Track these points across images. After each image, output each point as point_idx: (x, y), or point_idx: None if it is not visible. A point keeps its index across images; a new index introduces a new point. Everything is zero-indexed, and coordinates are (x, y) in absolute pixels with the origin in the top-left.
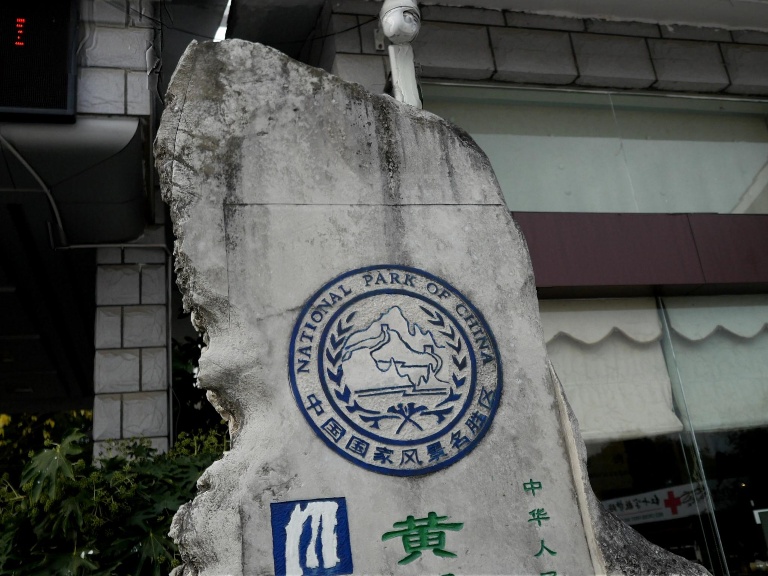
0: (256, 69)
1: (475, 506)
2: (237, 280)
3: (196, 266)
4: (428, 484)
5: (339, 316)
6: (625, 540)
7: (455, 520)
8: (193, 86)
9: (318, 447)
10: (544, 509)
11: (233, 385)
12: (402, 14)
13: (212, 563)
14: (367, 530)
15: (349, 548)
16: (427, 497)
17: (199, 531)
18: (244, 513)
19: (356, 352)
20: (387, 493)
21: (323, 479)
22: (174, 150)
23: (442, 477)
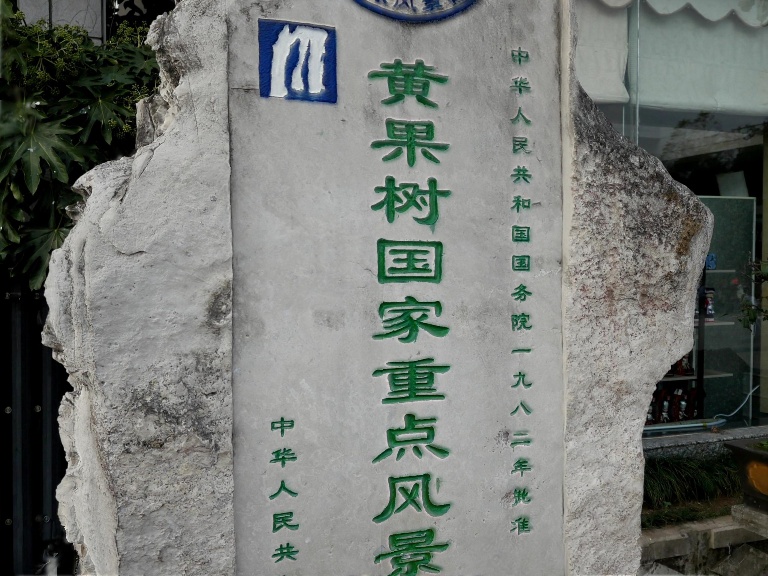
0: None
1: (462, 62)
2: None
3: None
4: (419, 31)
5: None
6: (597, 119)
7: (441, 72)
8: None
9: None
10: (527, 78)
11: None
12: None
13: (195, 68)
14: (354, 64)
15: (335, 78)
16: (417, 44)
17: (182, 34)
18: (231, 23)
19: None
20: (378, 32)
21: (314, 4)
22: None
23: (434, 27)
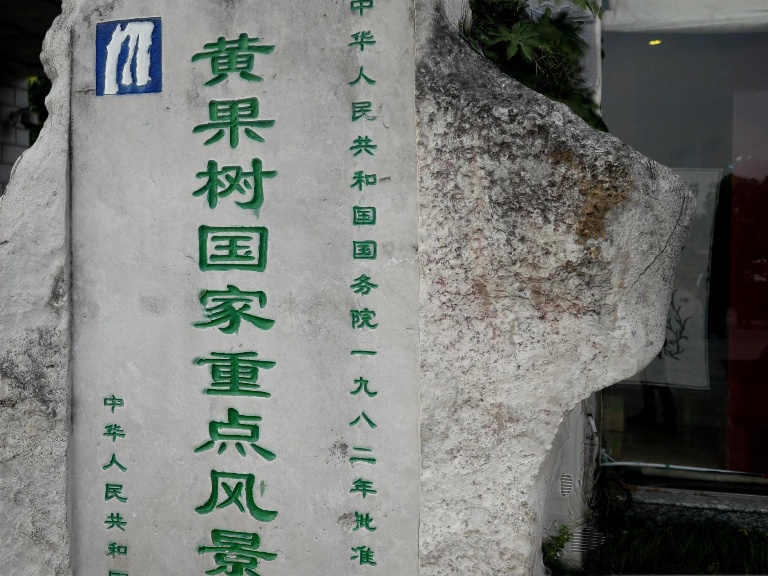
0: None
1: (291, 27)
2: None
3: None
4: (244, 3)
5: None
6: (455, 67)
7: (267, 42)
8: None
9: None
10: (370, 31)
11: None
12: None
13: (55, 78)
14: (179, 50)
15: (160, 67)
16: (241, 17)
17: (48, 50)
18: (75, 32)
19: None
20: (201, 13)
21: None
22: None
23: None
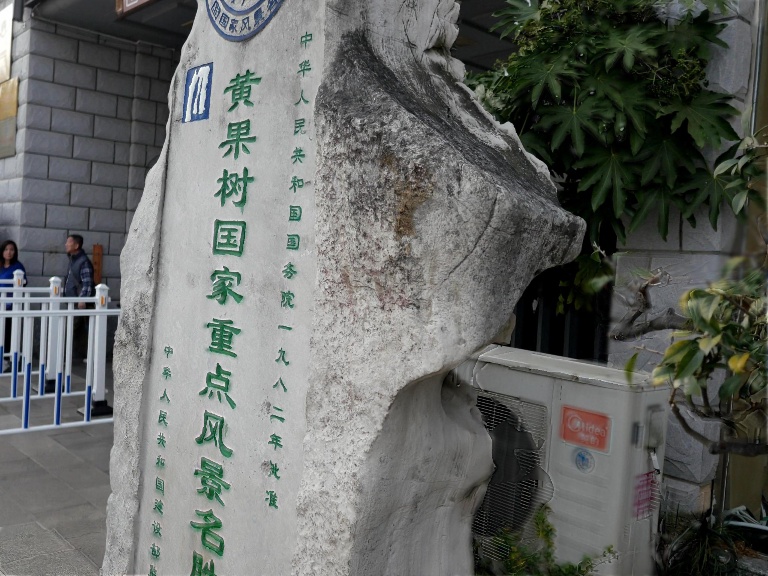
0: None
1: (270, 62)
2: None
3: None
4: (250, 46)
5: None
6: (343, 86)
7: (258, 75)
8: None
9: (208, 25)
10: (309, 60)
11: None
12: None
13: None
14: None
15: (209, 100)
16: (248, 57)
17: None
18: None
19: None
20: (230, 56)
21: (207, 49)
22: None
23: (258, 39)
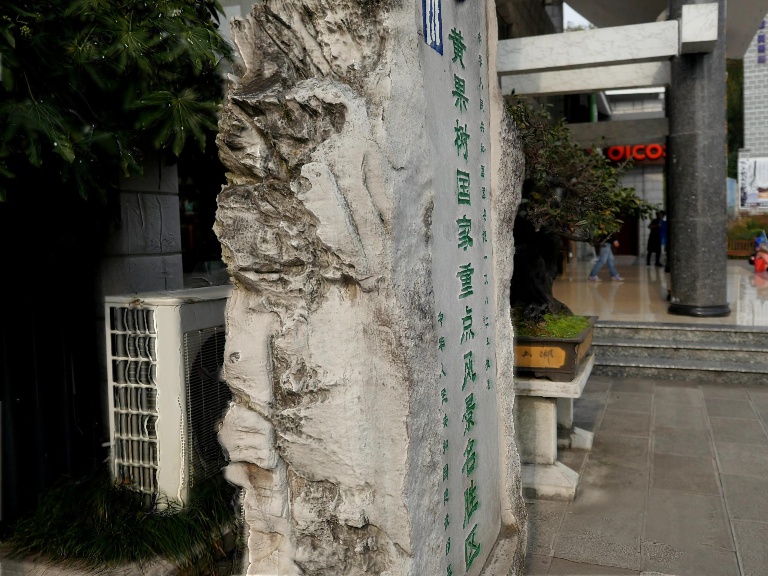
0: None
1: None
2: None
3: None
4: None
5: None
6: None
7: None
8: None
9: None
10: None
11: None
12: None
13: (397, 7)
14: None
15: None
16: None
17: None
18: None
19: None
20: (450, 3)
21: None
22: None
23: None
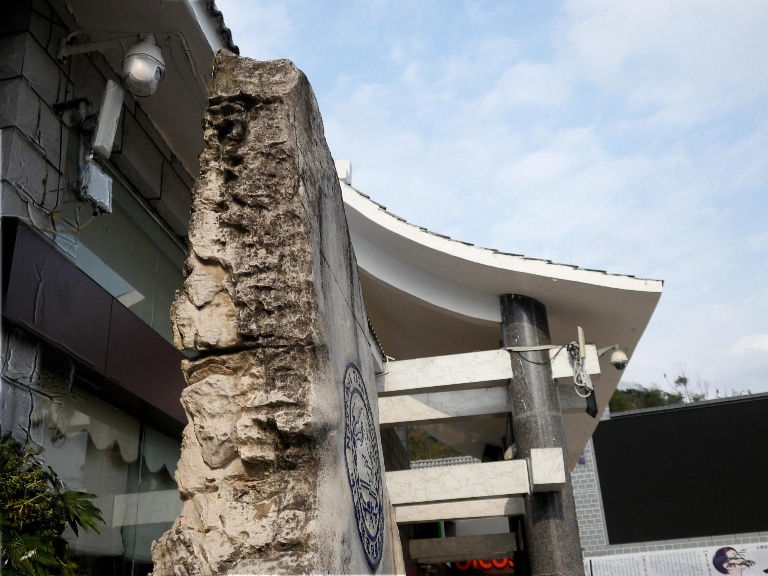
0: (320, 129)
1: None
2: (329, 334)
3: (318, 304)
4: None
5: (351, 402)
6: None
7: None
8: (299, 109)
9: None
10: None
11: (322, 442)
12: (156, 67)
13: None
14: None
15: None
16: None
17: None
18: None
19: (358, 442)
20: None
21: None
22: (299, 167)
23: (378, 575)
